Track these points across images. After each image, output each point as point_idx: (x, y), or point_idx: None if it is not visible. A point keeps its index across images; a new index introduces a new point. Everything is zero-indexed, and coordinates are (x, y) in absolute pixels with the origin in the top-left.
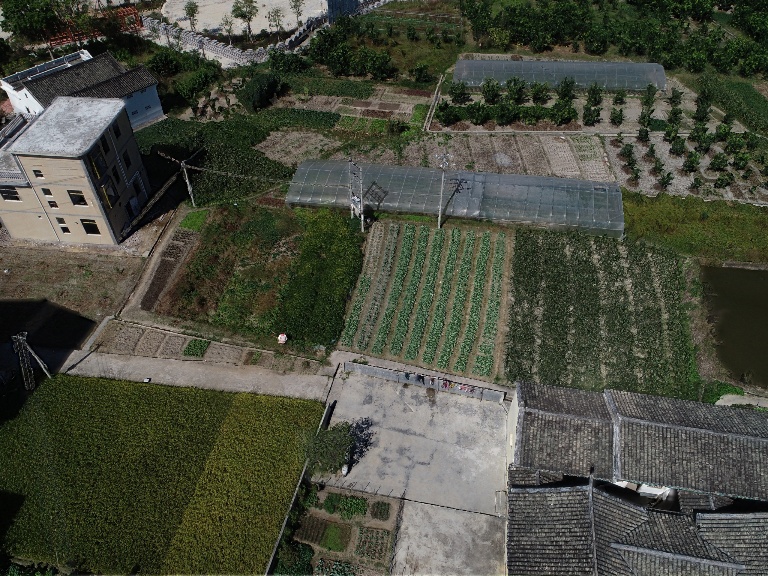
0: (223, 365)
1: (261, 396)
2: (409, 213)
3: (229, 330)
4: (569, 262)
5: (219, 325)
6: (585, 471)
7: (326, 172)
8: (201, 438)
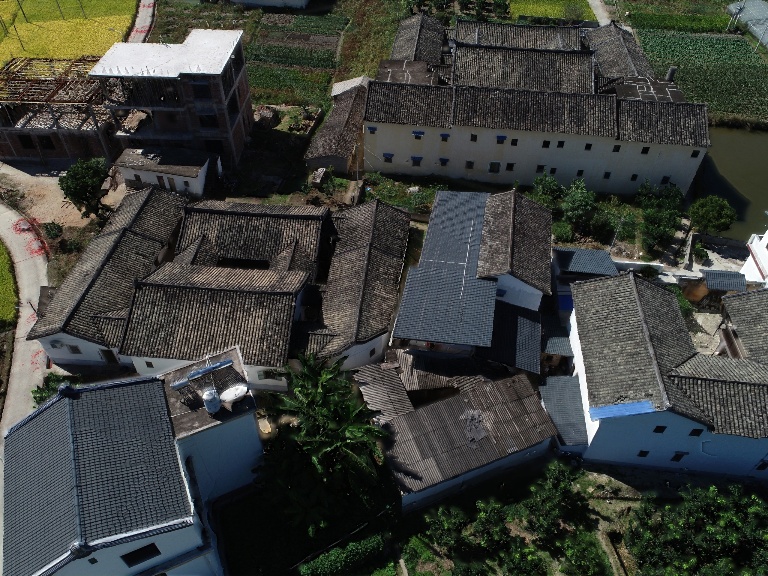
0: (604, 8)
1: (593, 13)
2: (760, 43)
3: (624, 6)
4: (759, 81)
5: (625, 4)
6: (592, 43)
7: (761, 5)
8: (566, 5)
